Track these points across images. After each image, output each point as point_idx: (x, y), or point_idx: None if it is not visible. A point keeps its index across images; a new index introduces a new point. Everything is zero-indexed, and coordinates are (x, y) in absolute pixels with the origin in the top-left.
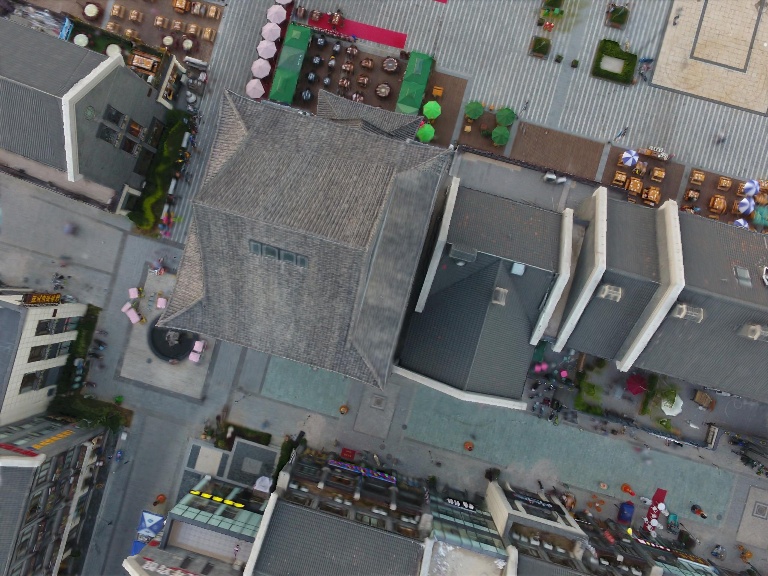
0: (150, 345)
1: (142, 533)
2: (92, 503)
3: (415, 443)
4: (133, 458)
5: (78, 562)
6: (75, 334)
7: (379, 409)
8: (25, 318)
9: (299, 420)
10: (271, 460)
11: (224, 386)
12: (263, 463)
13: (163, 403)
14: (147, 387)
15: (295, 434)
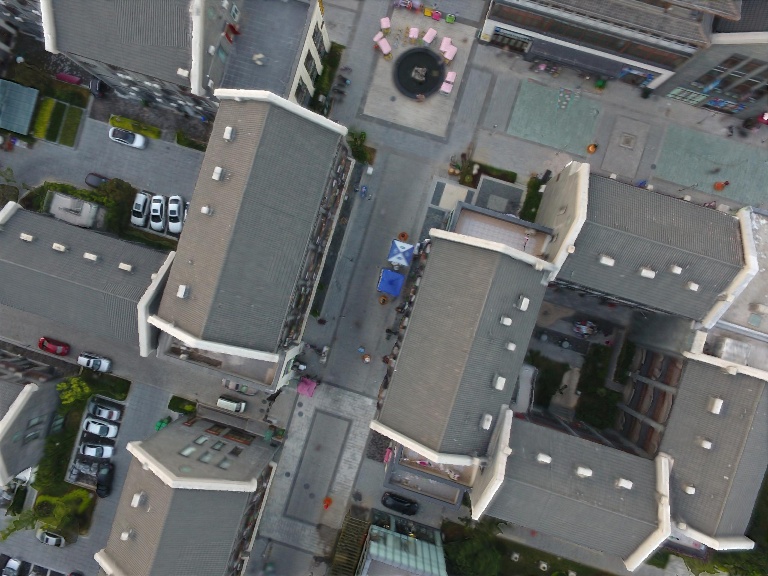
0: (395, 82)
1: (393, 261)
2: (334, 240)
3: (664, 183)
4: (375, 196)
5: (318, 298)
6: (321, 69)
7: (628, 148)
8: (314, 6)
9: (545, 159)
10: (517, 198)
11: (469, 124)
12: (509, 201)
13: (407, 141)
14: (390, 125)
15: (541, 173)
